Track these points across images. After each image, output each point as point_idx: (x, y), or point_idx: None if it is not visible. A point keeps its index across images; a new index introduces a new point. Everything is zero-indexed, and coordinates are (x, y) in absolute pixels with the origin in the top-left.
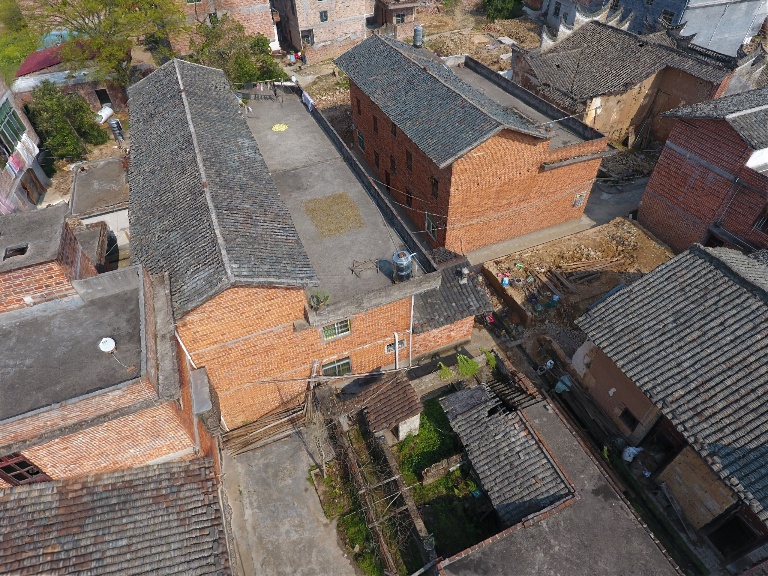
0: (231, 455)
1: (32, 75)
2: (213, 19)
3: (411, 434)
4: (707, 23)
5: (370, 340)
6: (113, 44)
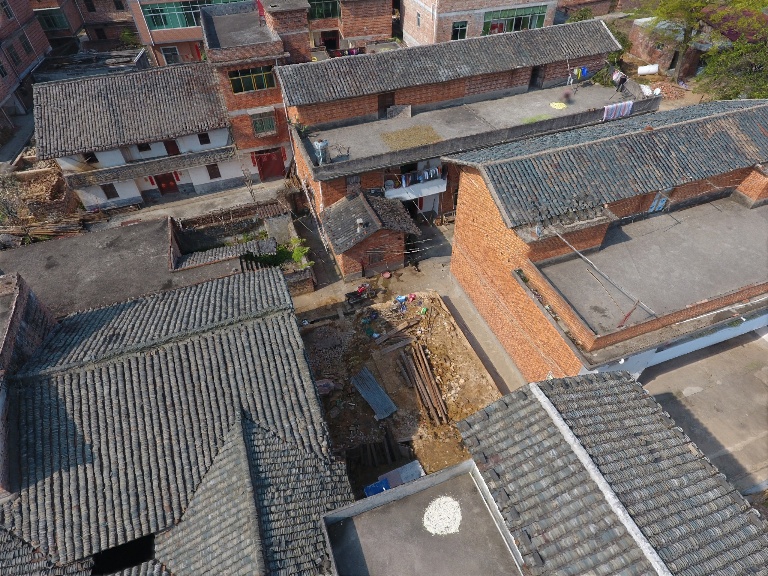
0: (285, 181)
1: (614, 6)
2: None
3: None
4: None
5: None
6: (666, 5)
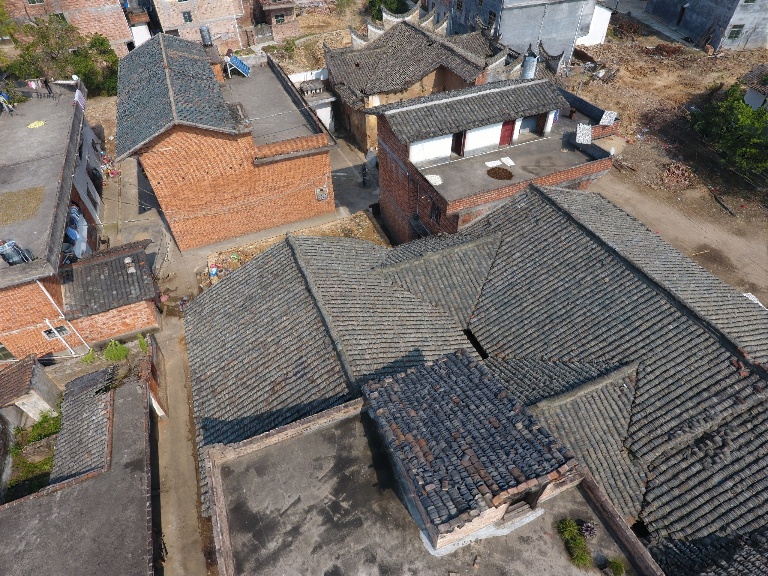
0: None
1: None
2: (37, 19)
3: (48, 415)
4: (530, 23)
5: (16, 326)
6: None
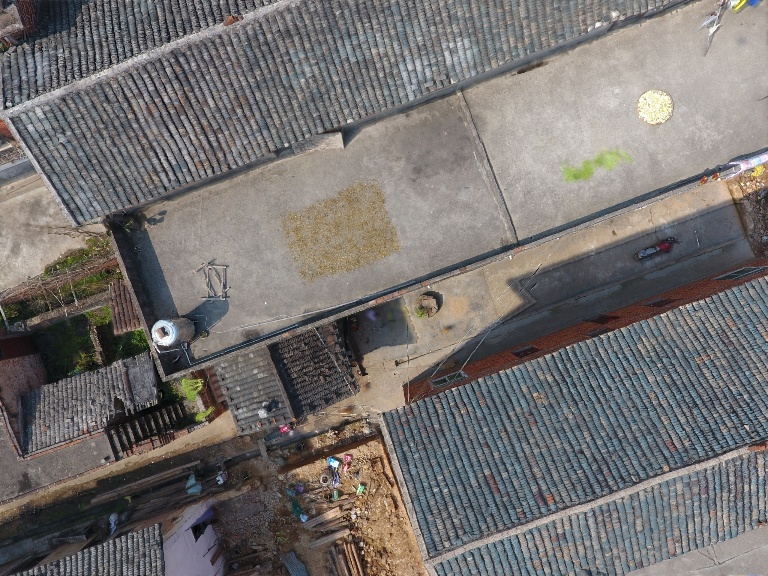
0: None
1: None
2: None
3: None
4: None
5: None
6: None
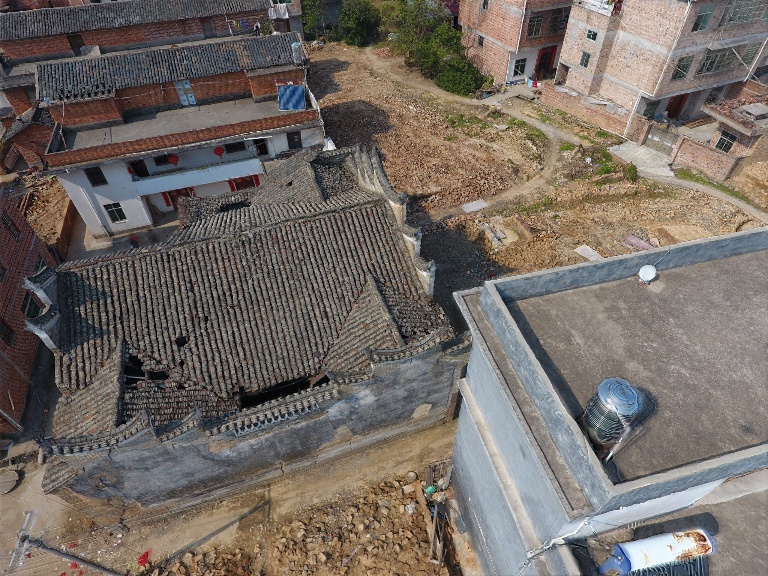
0: None
1: None
2: None
3: None
4: None
5: None
6: None
